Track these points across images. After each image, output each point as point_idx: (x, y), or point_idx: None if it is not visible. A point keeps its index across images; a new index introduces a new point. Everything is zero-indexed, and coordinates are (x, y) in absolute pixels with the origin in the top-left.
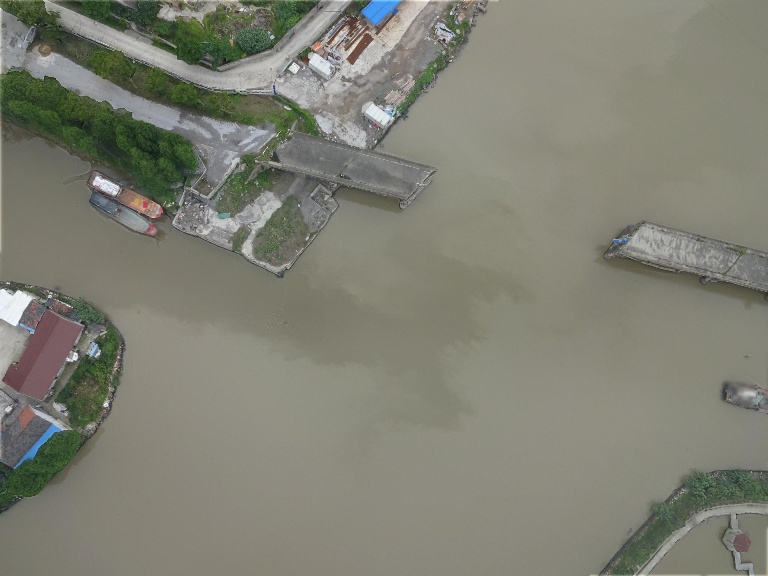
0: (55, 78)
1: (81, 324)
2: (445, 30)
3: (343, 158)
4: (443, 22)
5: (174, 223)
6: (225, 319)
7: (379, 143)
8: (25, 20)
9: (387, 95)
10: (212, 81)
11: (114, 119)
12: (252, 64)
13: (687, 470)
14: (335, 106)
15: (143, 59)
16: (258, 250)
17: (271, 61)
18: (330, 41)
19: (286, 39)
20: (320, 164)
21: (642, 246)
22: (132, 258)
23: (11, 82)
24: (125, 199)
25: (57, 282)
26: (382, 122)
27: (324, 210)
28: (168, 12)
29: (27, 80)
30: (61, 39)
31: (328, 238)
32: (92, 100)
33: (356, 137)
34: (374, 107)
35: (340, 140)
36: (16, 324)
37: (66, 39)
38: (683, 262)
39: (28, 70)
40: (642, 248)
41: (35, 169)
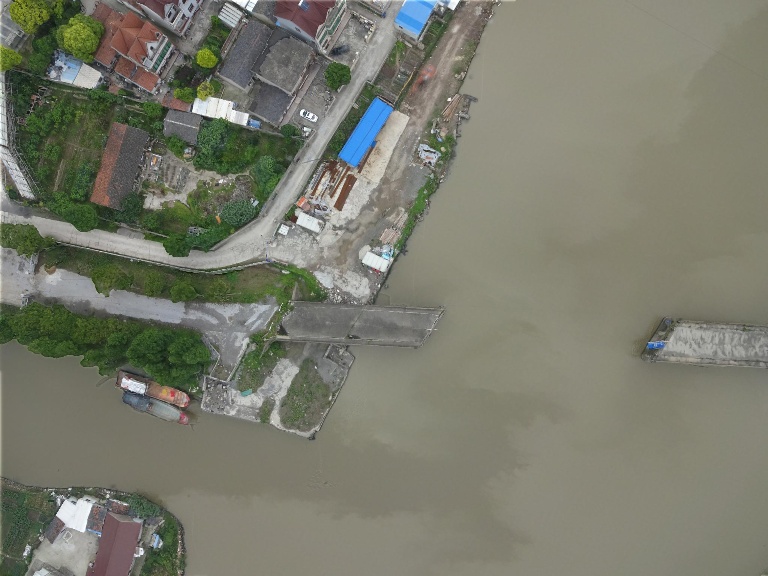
0: (63, 305)
1: (140, 519)
2: (429, 151)
3: (348, 318)
4: (425, 142)
5: (202, 408)
6: (268, 489)
7: (383, 285)
8: (25, 253)
9: (382, 235)
10: (208, 262)
11: (123, 338)
12: (242, 235)
13: (767, 567)
14: (332, 258)
15: (139, 255)
16: (285, 420)
17: (260, 228)
18: (314, 192)
19: (270, 202)
20: (327, 329)
21: (680, 349)
22: (172, 445)
23: (25, 323)
24: (153, 391)
25: (111, 480)
26: (381, 269)
27: (341, 366)
28: (153, 200)
29: (39, 314)
30: (62, 255)
31: (351, 392)
32: (100, 322)
33: (359, 286)
34: (370, 255)
35: (343, 292)
36: (84, 531)
37: (66, 253)
38: (730, 357)
39: (40, 291)
40: (681, 351)
41: (72, 361)
